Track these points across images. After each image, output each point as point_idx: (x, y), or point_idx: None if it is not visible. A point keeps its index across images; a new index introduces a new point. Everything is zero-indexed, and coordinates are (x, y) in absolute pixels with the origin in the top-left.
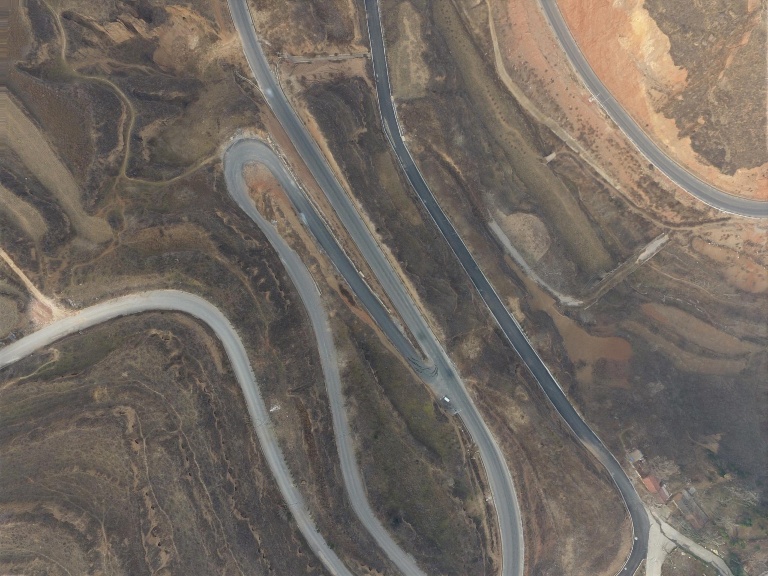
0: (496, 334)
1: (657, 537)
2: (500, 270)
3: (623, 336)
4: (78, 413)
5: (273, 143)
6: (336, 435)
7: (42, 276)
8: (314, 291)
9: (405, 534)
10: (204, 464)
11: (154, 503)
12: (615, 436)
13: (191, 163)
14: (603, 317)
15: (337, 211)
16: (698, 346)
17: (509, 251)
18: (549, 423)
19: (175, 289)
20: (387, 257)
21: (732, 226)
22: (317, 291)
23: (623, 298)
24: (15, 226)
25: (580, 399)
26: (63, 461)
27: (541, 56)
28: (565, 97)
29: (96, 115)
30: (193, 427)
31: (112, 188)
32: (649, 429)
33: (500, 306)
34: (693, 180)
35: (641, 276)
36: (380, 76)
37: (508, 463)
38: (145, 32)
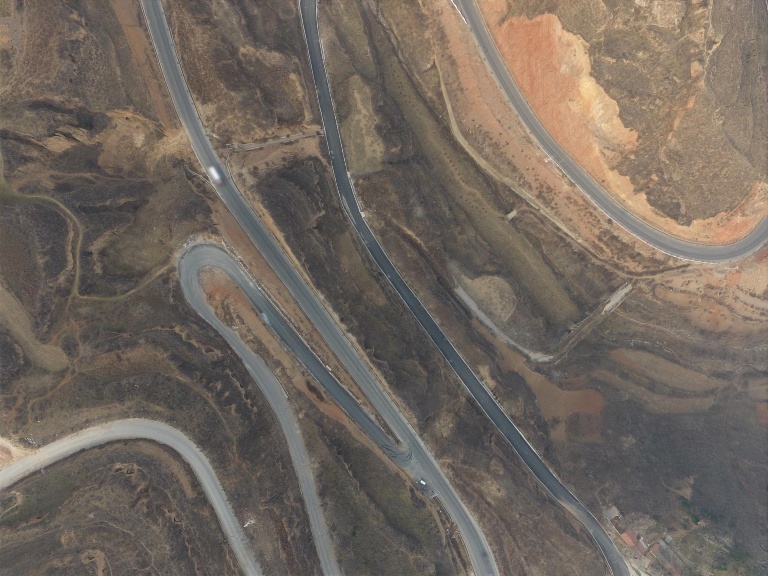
0: (469, 404)
1: None
2: (468, 340)
3: (594, 387)
4: (45, 562)
5: (228, 246)
6: (314, 536)
7: None
8: (281, 394)
9: None
10: None
11: None
12: (591, 495)
13: (145, 273)
14: (574, 368)
15: (300, 303)
16: (668, 387)
17: (477, 315)
18: (525, 493)
19: (137, 418)
20: (353, 345)
21: (692, 272)
22: (284, 394)
23: (592, 346)
24: None
25: (555, 461)
26: None
27: (494, 120)
28: (521, 158)
29: (41, 240)
30: (165, 562)
31: (65, 310)
32: (624, 483)
33: (471, 375)
34: (651, 231)
35: (608, 323)
36: (335, 152)
37: (488, 539)
38: (87, 140)
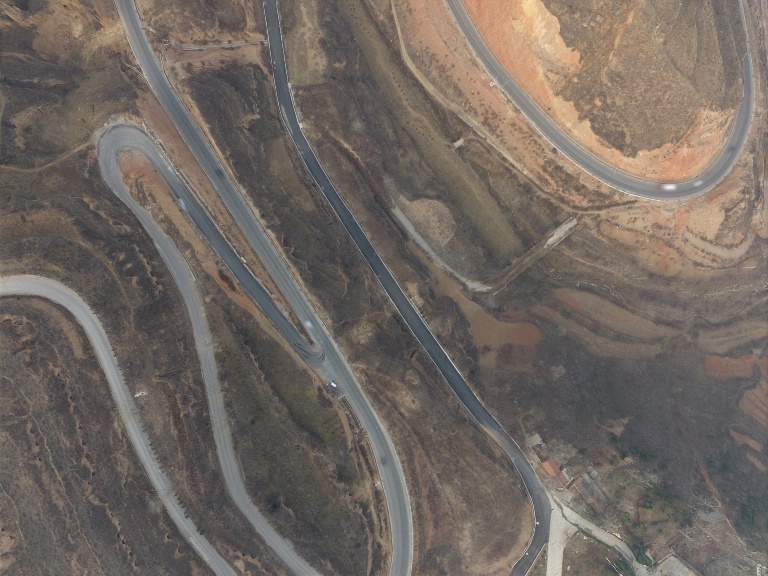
0: (394, 320)
1: (559, 521)
2: (398, 255)
3: (532, 321)
4: None
5: (148, 129)
6: (212, 421)
7: None
8: (189, 276)
9: (283, 519)
10: (55, 449)
11: None
12: (513, 420)
13: (66, 150)
14: (514, 303)
15: (222, 197)
16: (613, 331)
17: (413, 237)
18: (441, 407)
19: (32, 274)
20: (273, 243)
21: (638, 209)
22: (192, 276)
23: (536, 284)
24: None
25: (480, 384)
26: None
27: (440, 41)
28: (466, 82)
29: None
30: (43, 412)
31: None
32: (550, 413)
33: (399, 292)
34: (597, 163)
35: (554, 261)
36: (277, 63)
37: (397, 448)
38: (21, 20)
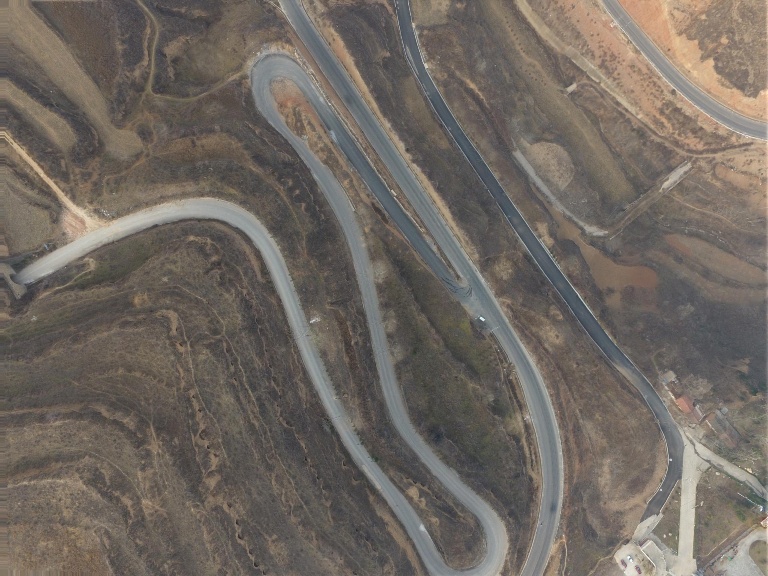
0: (526, 260)
1: (691, 458)
2: (528, 195)
3: (649, 265)
4: (119, 318)
5: (301, 58)
6: (375, 352)
7: (73, 187)
8: (348, 206)
9: (447, 449)
10: (249, 369)
11: (201, 406)
12: (648, 357)
13: (217, 81)
14: (628, 248)
15: (365, 132)
16: (722, 276)
17: (534, 181)
18: (584, 342)
19: (211, 197)
20: (417, 177)
21: (755, 151)
22: (351, 206)
23: (646, 230)
24: (43, 137)
25: (611, 322)
26: (107, 363)
27: None
28: (586, 23)
29: (121, 26)
30: (237, 331)
31: (139, 103)
32: (680, 351)
33: (529, 232)
34: (715, 105)
35: (663, 208)
36: (400, 3)
37: (545, 381)
38: None
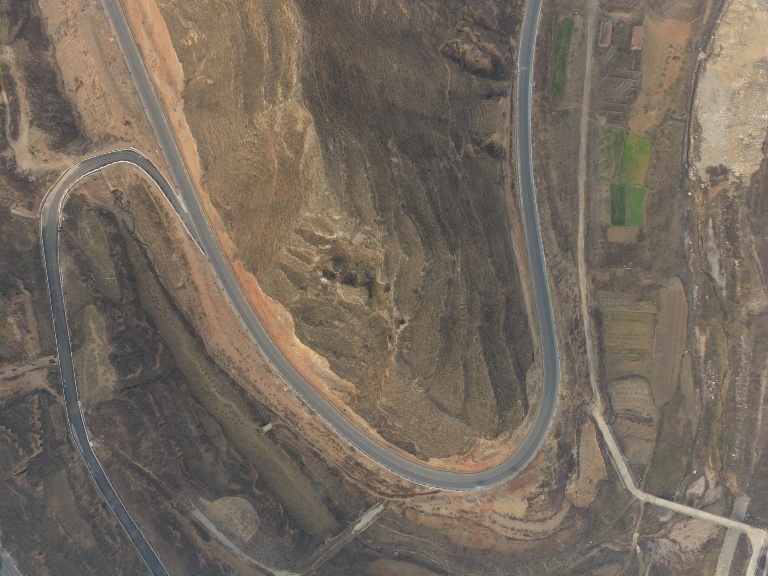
0: None
1: None
2: (187, 575)
3: None
4: None
5: None
6: None
7: None
8: None
9: None
10: None
11: None
12: None
13: None
14: None
15: None
16: None
17: (215, 536)
18: None
19: None
20: None
21: (441, 500)
22: None
23: (353, 556)
24: None
25: None
26: None
27: (233, 348)
28: (262, 385)
29: None
30: None
31: None
32: None
33: None
34: (397, 459)
35: (371, 532)
36: (67, 381)
37: None
38: None
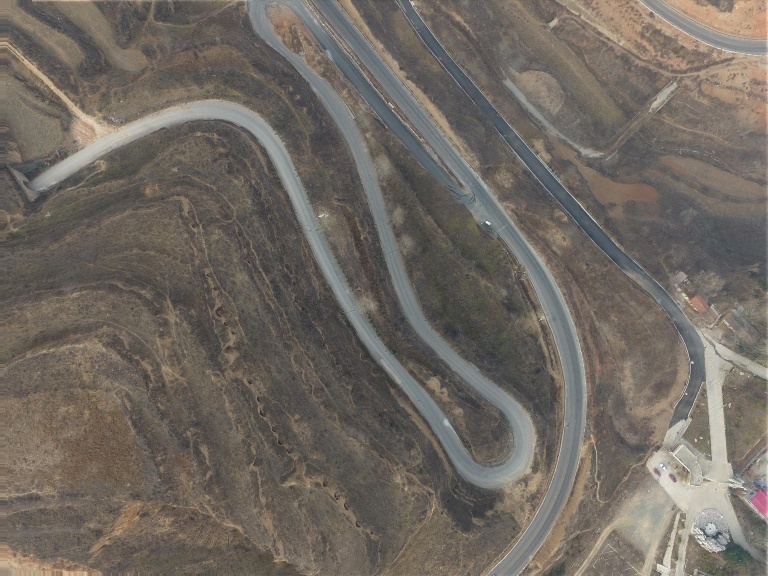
0: (525, 175)
1: (713, 359)
2: (521, 115)
3: (647, 181)
4: (131, 206)
5: None
6: (384, 252)
7: (82, 97)
8: (348, 115)
9: (465, 344)
10: (261, 252)
11: (216, 285)
12: (657, 259)
13: None
14: (625, 169)
15: (359, 56)
16: (720, 193)
17: (526, 107)
18: None
19: (215, 99)
20: (413, 94)
21: (737, 65)
22: (351, 115)
23: None
24: (52, 57)
25: (616, 230)
26: (121, 245)
27: None
28: None
29: None
30: (247, 216)
31: (142, 30)
32: (688, 253)
33: (526, 149)
34: (693, 24)
35: (655, 131)
36: None
37: (557, 281)
38: None
